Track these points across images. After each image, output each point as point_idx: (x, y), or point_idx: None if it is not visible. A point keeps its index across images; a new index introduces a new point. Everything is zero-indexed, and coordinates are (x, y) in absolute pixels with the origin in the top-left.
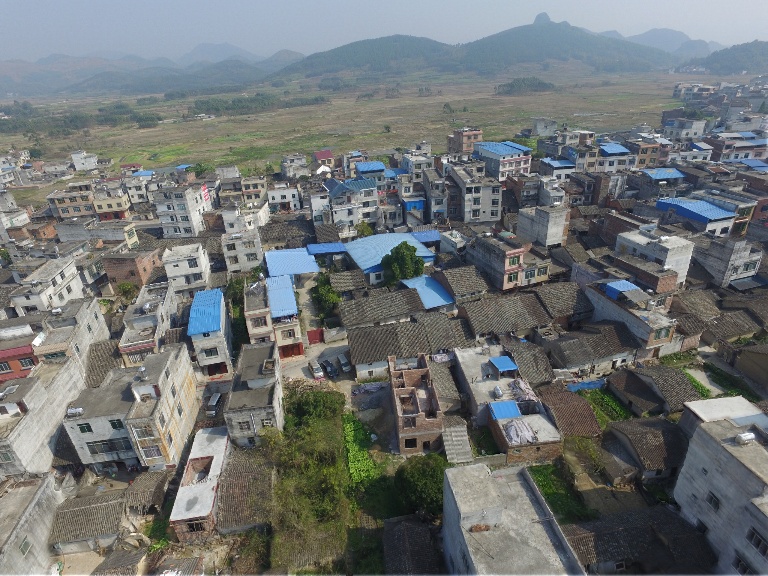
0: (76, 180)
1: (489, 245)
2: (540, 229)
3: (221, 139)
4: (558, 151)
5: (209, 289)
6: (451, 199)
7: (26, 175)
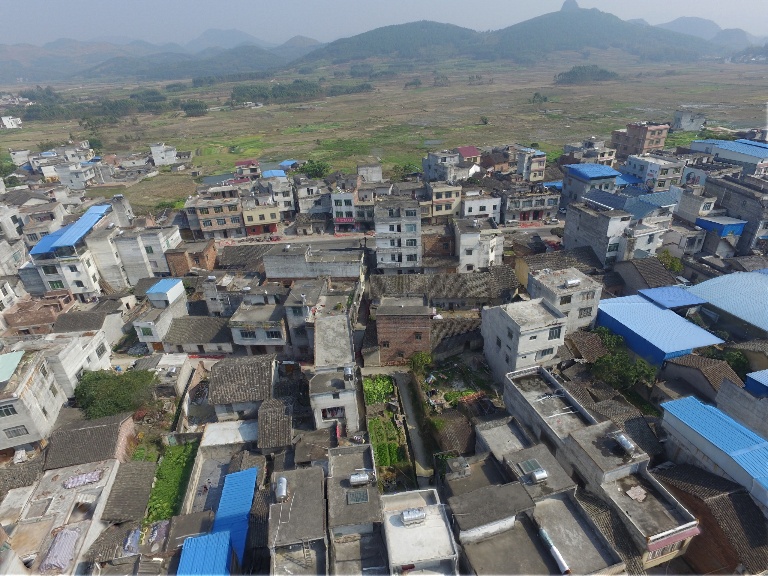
0: (163, 177)
1: None
2: None
3: (294, 130)
4: None
5: None
6: None
7: (109, 171)
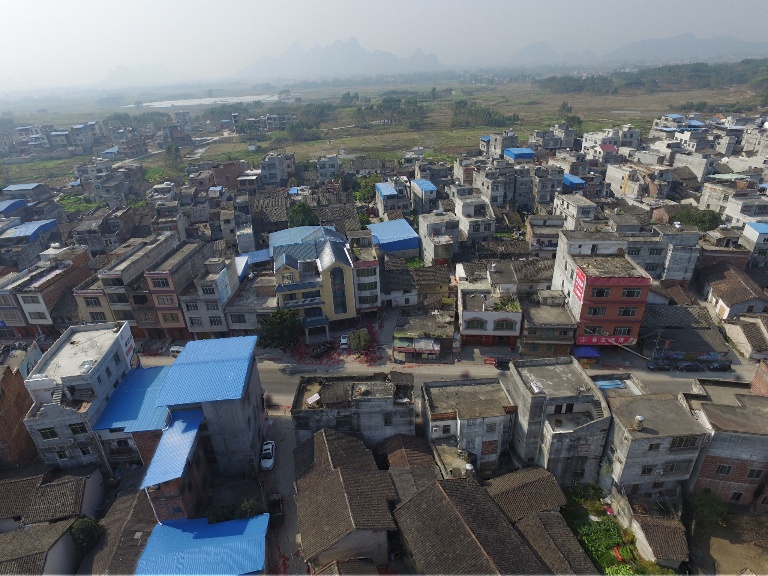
0: None
1: None
2: None
3: None
4: None
5: None
6: None
7: None
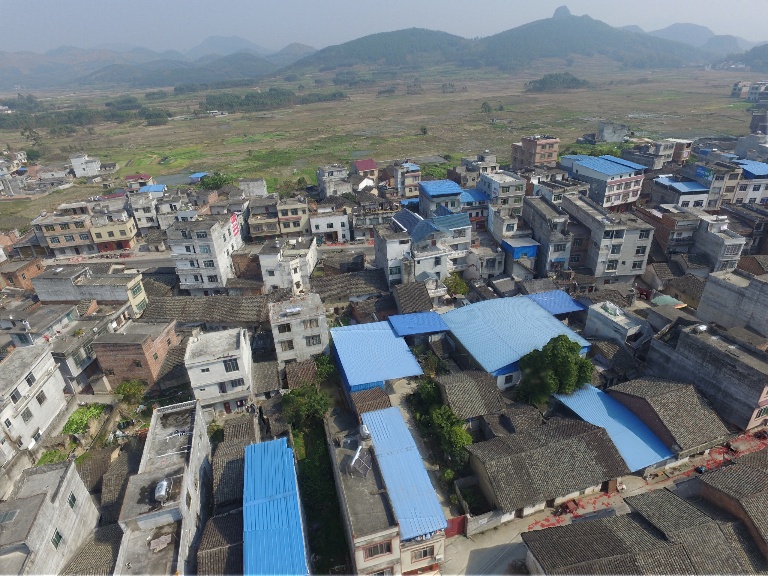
0: (75, 189)
1: (720, 354)
2: (758, 310)
3: (237, 140)
4: (653, 165)
5: (253, 396)
6: (574, 243)
7: (17, 184)
